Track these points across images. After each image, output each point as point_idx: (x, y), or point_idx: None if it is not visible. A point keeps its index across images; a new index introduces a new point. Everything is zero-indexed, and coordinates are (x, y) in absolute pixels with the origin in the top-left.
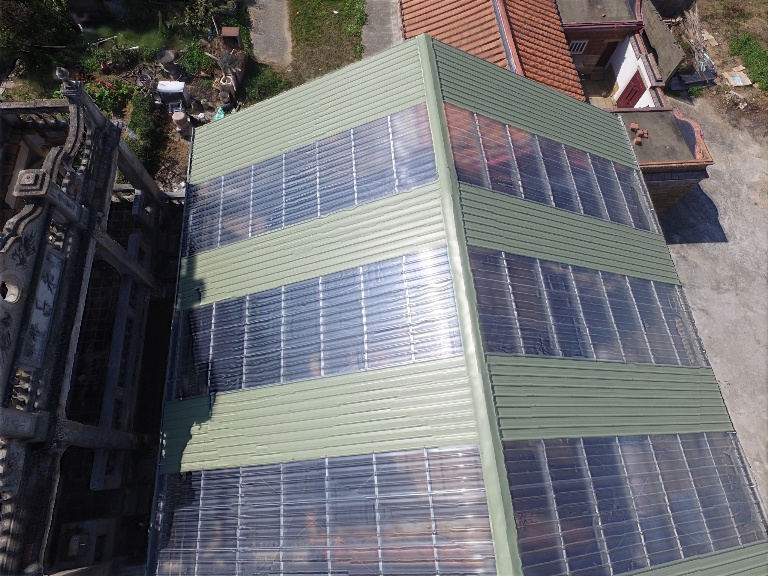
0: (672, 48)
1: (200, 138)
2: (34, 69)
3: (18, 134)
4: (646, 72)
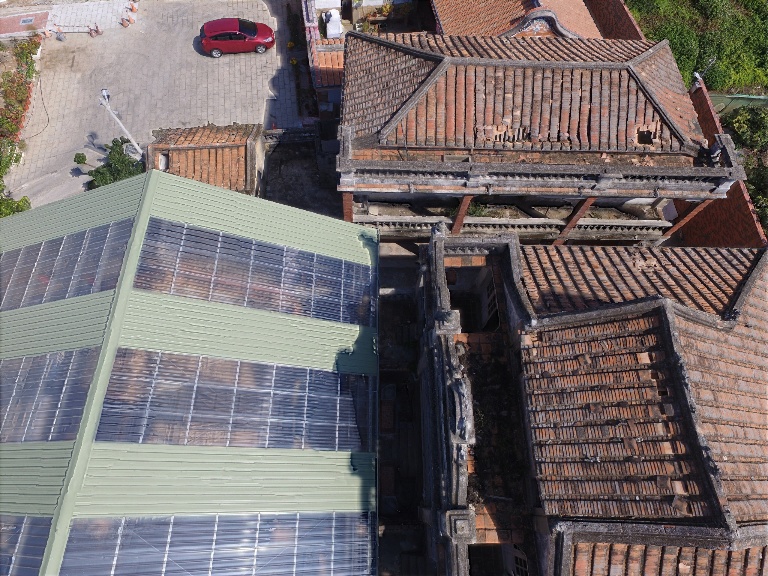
0: None
1: None
2: None
3: None
4: None
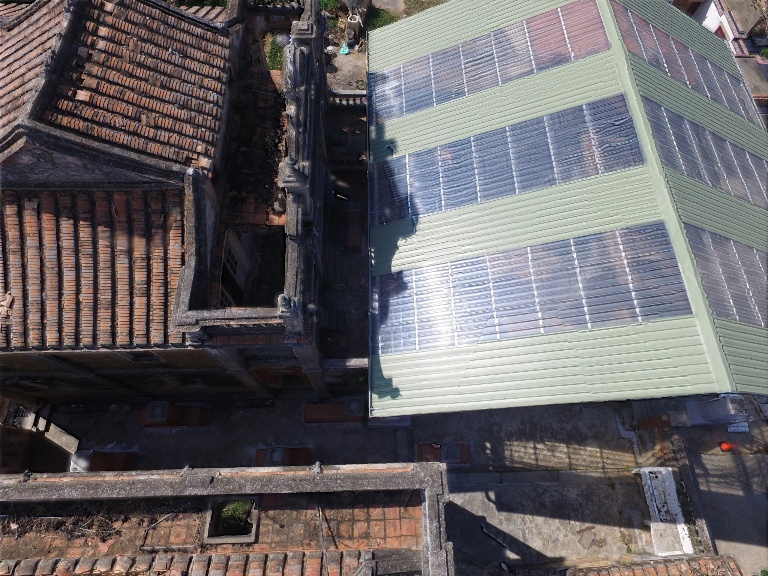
0: (749, 11)
1: (374, 39)
2: (184, 3)
3: (252, 15)
4: (729, 26)
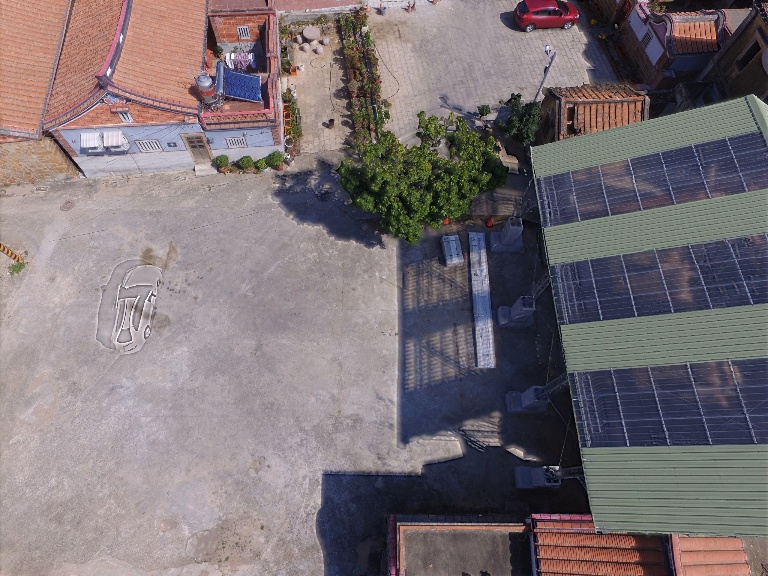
0: None
1: None
2: None
3: None
4: None
